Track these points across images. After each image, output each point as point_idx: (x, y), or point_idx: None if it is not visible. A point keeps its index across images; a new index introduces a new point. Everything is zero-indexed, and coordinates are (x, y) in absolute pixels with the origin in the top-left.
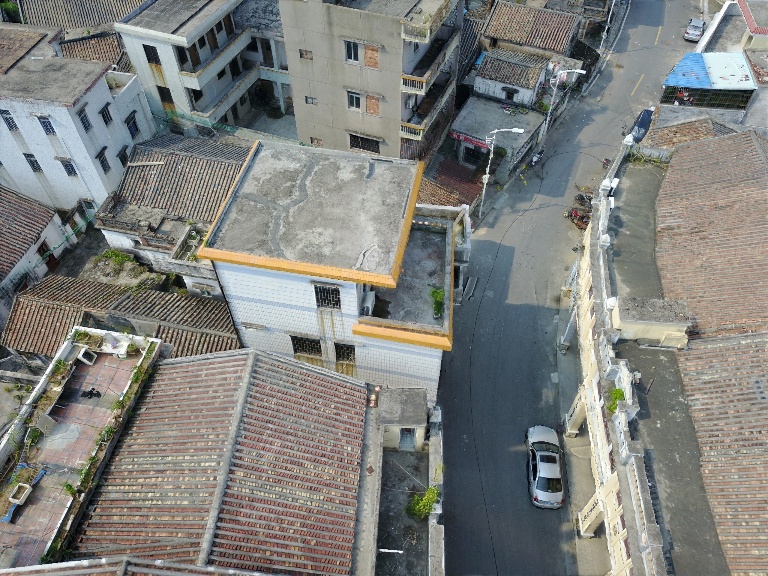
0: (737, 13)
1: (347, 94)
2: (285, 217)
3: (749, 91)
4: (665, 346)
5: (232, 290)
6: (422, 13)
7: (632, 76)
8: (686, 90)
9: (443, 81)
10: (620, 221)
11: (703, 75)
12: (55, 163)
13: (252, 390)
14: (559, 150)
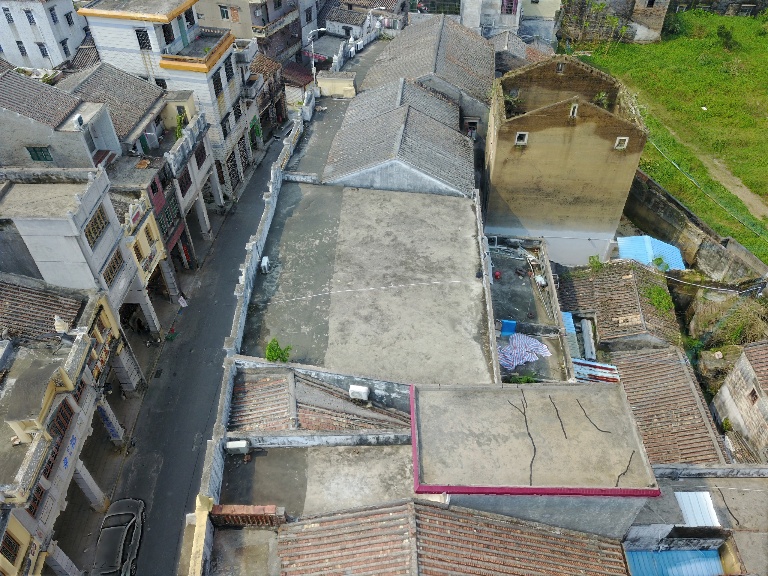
0: None
1: (220, 9)
2: (127, 3)
3: (458, 1)
4: (346, 98)
5: (99, 42)
6: None
7: None
8: (422, 2)
9: None
10: (358, 61)
11: None
12: (35, 47)
13: (97, 74)
14: None
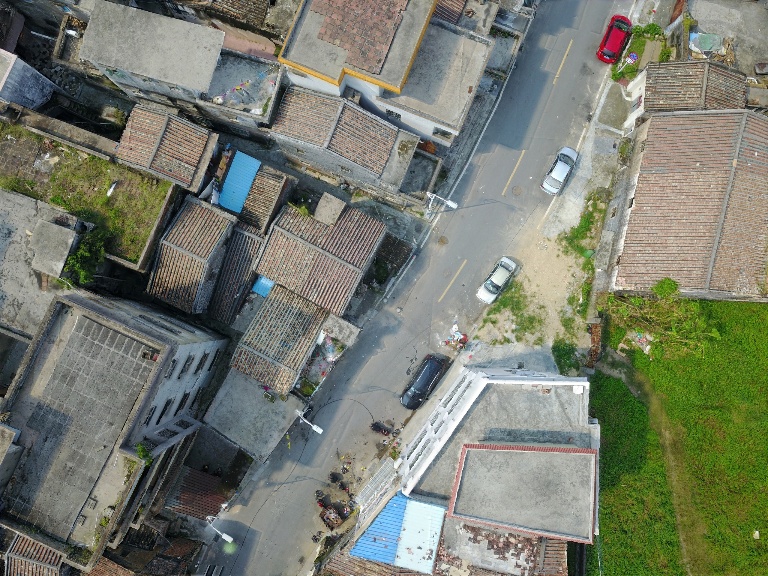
0: None
1: None
2: None
3: None
4: None
5: None
6: (97, 507)
7: (452, 263)
8: None
9: None
10: None
11: (393, 542)
12: None
13: None
14: (334, 397)
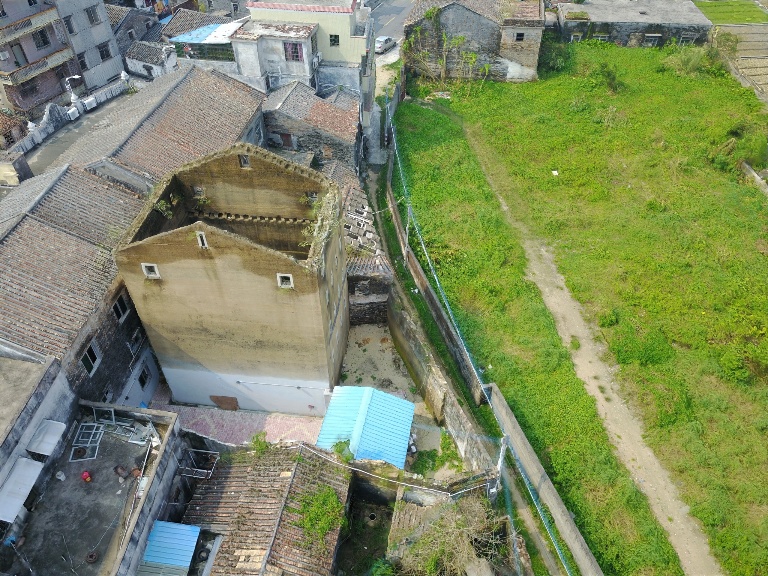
0: None
1: None
2: None
3: (229, 45)
4: (11, 185)
5: None
6: None
7: None
8: (188, 45)
9: None
10: (79, 125)
11: (205, 35)
12: None
13: None
14: None
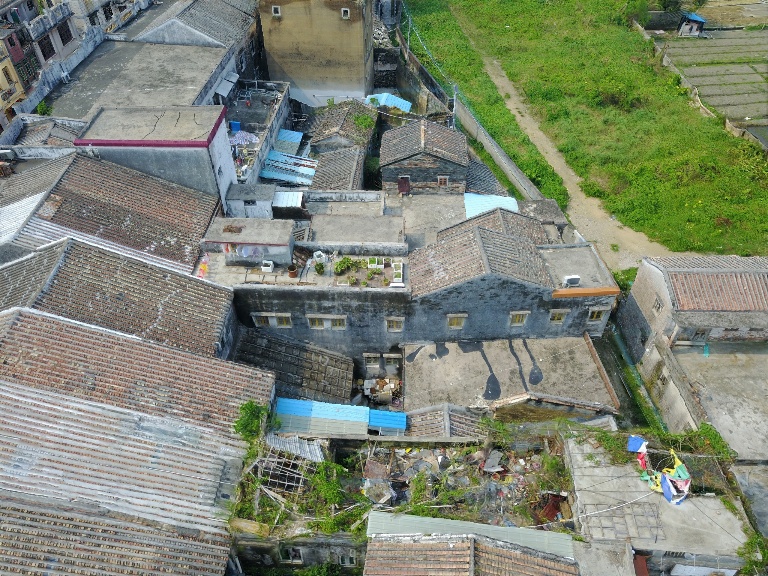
0: None
1: None
2: None
3: None
4: None
5: None
6: None
7: None
8: None
9: None
10: None
11: None
12: None
13: None
14: None
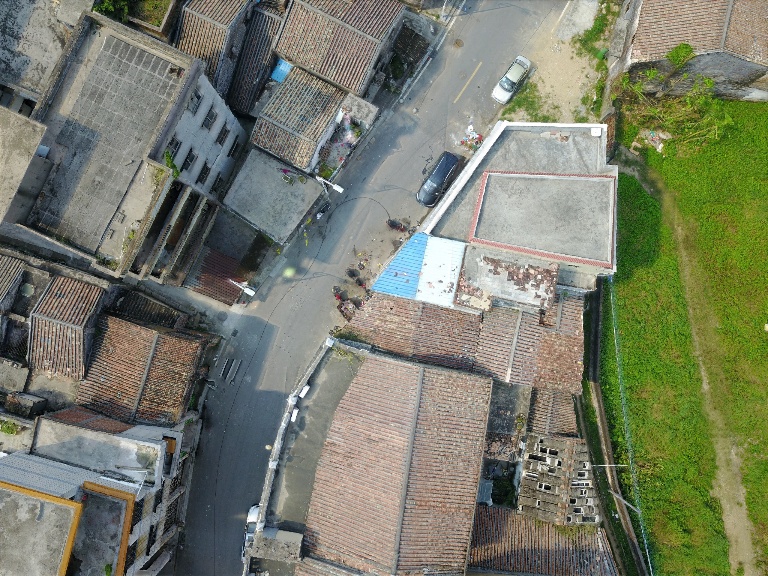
0: (517, 129)
1: None
2: None
3: None
4: None
5: None
6: (125, 221)
7: (467, 65)
8: None
9: (193, 196)
10: (304, 423)
11: (415, 276)
12: None
13: None
14: (351, 195)
